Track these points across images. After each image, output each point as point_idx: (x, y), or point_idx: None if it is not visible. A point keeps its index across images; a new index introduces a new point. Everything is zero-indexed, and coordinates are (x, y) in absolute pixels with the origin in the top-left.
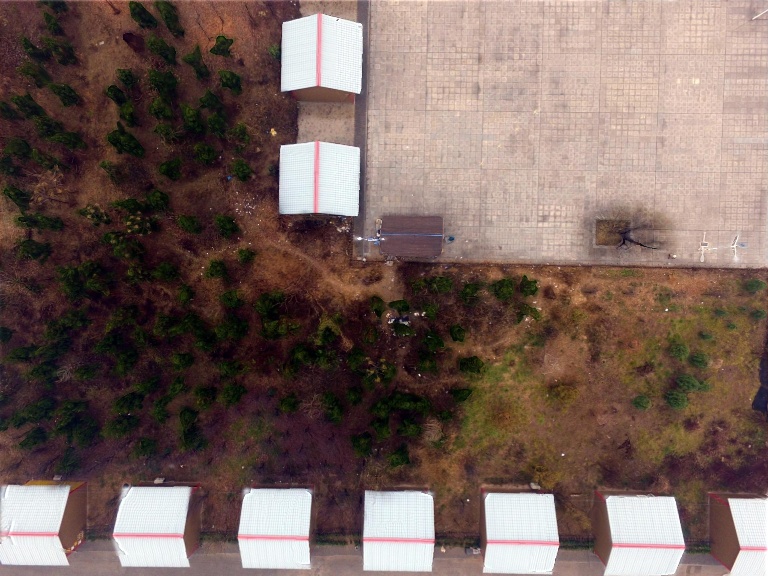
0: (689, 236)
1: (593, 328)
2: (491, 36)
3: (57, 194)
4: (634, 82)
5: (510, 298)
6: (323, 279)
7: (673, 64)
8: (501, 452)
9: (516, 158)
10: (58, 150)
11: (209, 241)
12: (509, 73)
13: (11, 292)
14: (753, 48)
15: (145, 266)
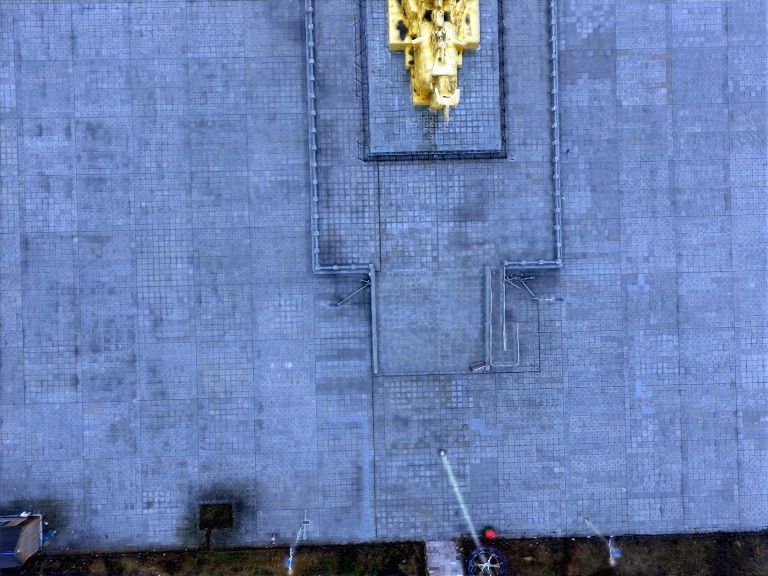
0: (291, 515)
1: None
2: (87, 329)
3: None
4: (229, 368)
5: None
6: None
7: (266, 349)
8: None
9: (118, 447)
10: None
11: None
12: (107, 364)
13: None
14: (340, 331)
15: None
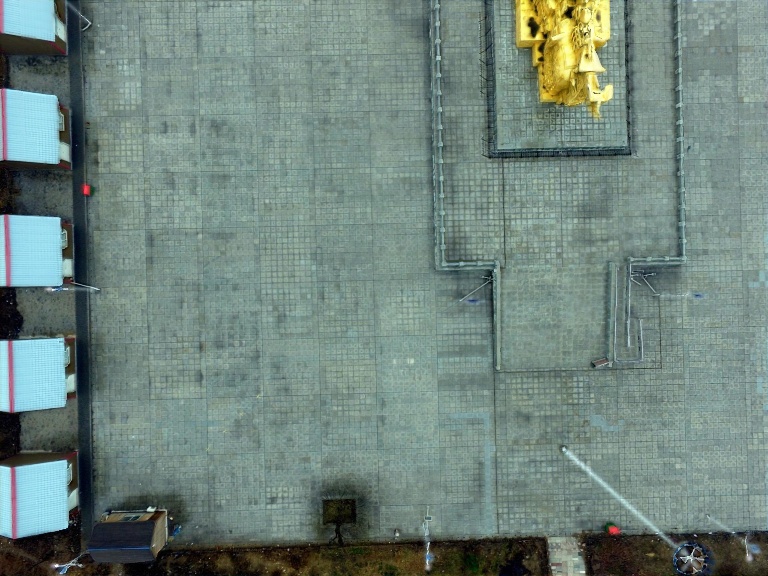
0: (413, 511)
1: None
2: (211, 325)
3: None
4: (352, 364)
5: None
6: None
7: (388, 345)
8: None
9: (242, 442)
10: None
11: None
12: (230, 360)
13: None
14: (462, 328)
15: None
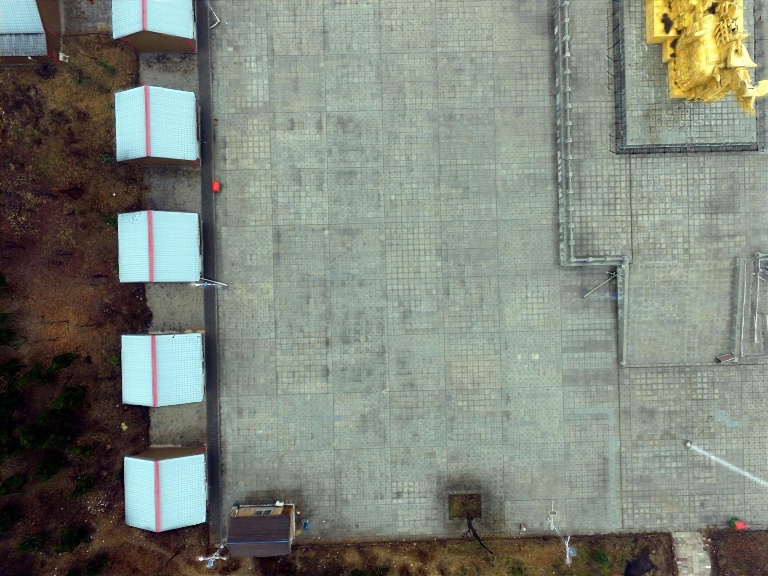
0: (538, 506)
1: None
2: (337, 320)
3: None
4: (477, 359)
5: None
6: (179, 572)
7: (513, 341)
8: None
9: (368, 437)
10: None
11: None
12: (356, 355)
13: None
14: (587, 323)
15: None
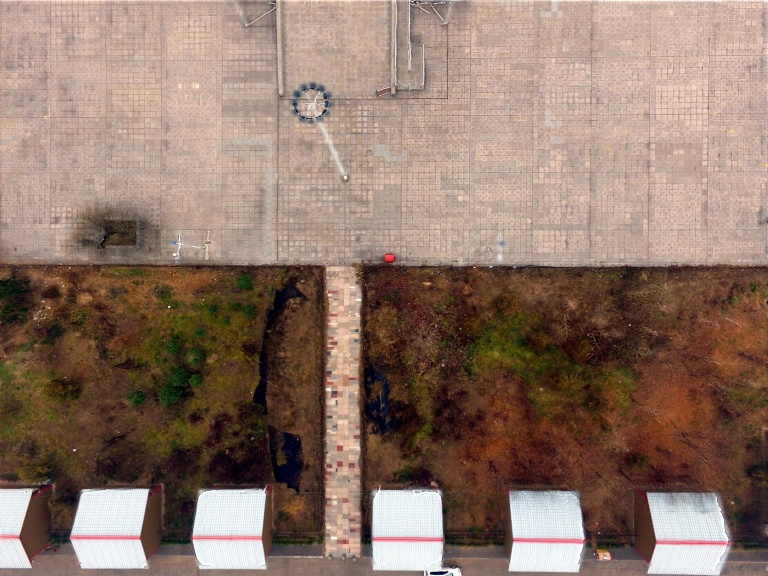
0: (194, 235)
1: (97, 326)
2: (1, 45)
3: None
4: (138, 87)
5: (1, 298)
6: None
7: (174, 70)
8: (14, 449)
9: (28, 162)
10: None
11: None
12: (19, 80)
13: None
14: (248, 54)
15: None
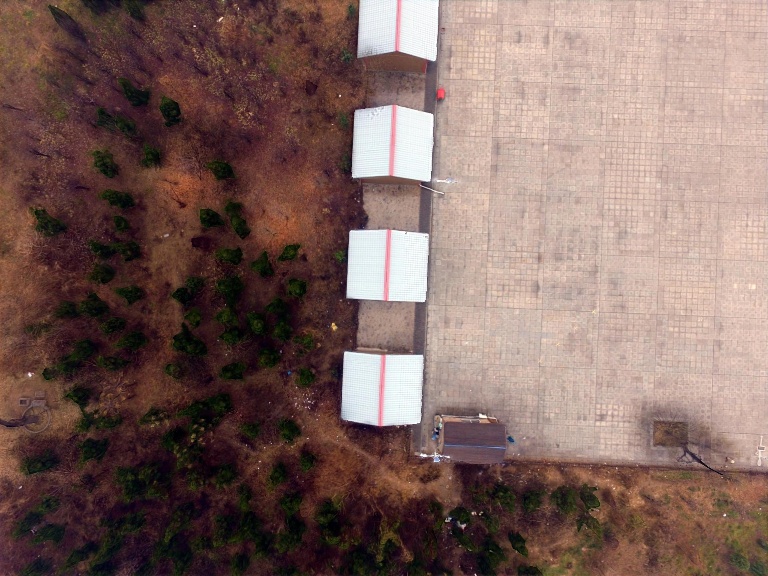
0: (746, 439)
1: (651, 533)
2: (551, 236)
3: (121, 402)
4: (691, 286)
5: None
6: (381, 476)
7: (730, 269)
8: None
9: (574, 357)
10: (118, 340)
11: (267, 435)
12: (568, 273)
13: (64, 482)
14: None
15: (206, 472)
